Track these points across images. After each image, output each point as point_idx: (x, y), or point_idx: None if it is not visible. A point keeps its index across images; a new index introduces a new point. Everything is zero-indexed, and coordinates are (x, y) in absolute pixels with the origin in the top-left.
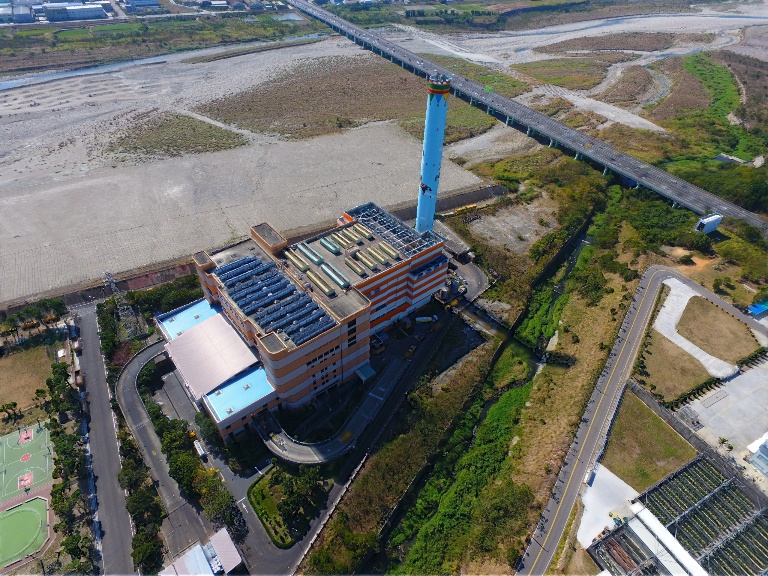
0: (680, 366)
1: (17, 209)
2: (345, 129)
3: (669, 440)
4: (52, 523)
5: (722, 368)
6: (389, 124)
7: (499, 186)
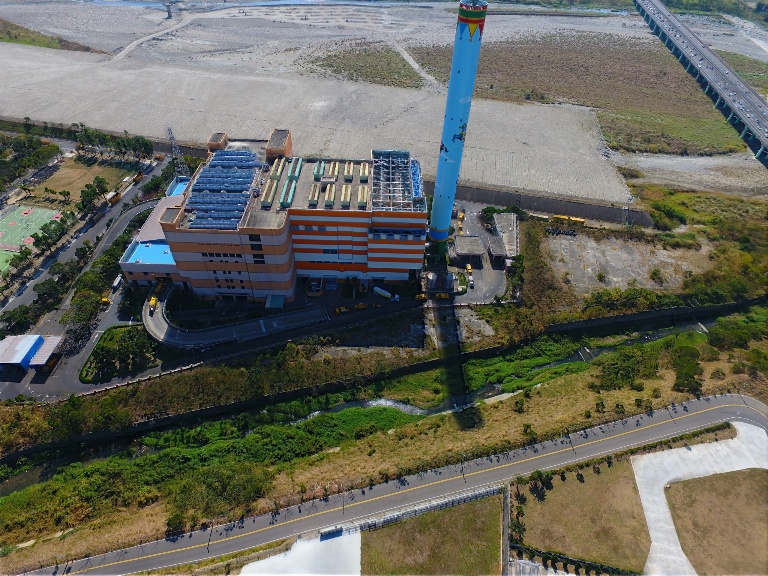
0: (607, 524)
1: (213, 82)
2: (530, 102)
3: None
4: (11, 271)
5: None
6: (585, 111)
7: (642, 213)
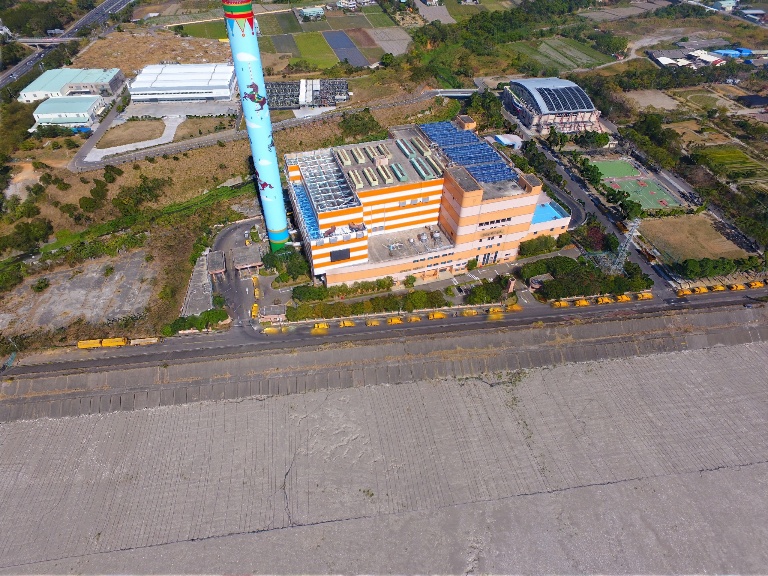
0: None
1: None
2: None
3: None
4: None
5: (172, 121)
6: None
7: None
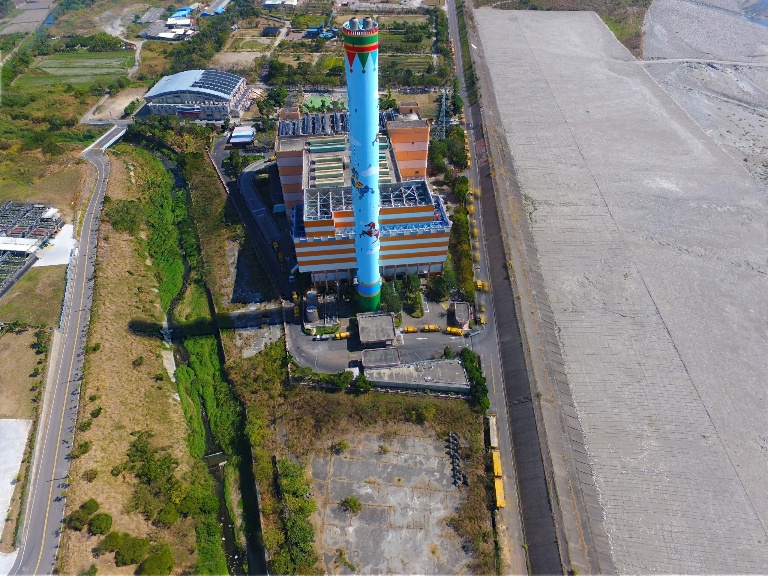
0: None
1: (639, 112)
2: None
3: (8, 316)
4: None
5: None
6: None
7: None
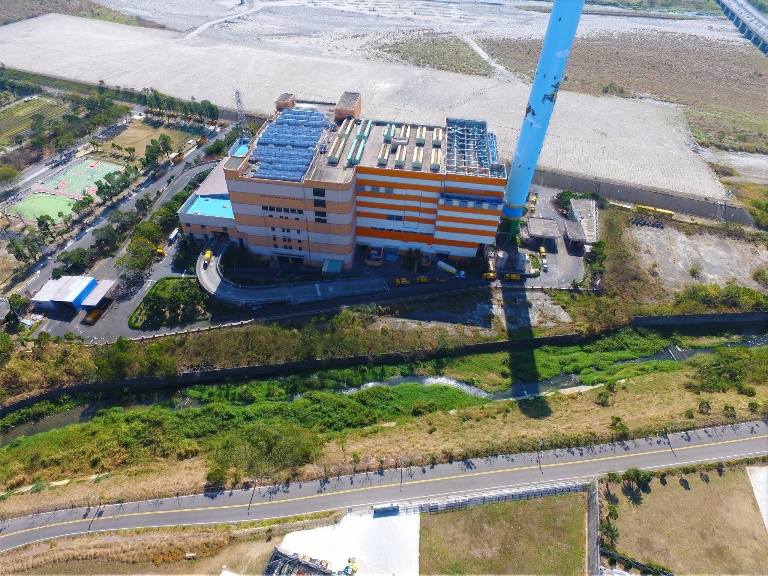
0: (721, 542)
1: (280, 61)
2: (608, 95)
3: None
4: (72, 217)
5: None
6: (670, 106)
7: (741, 210)
